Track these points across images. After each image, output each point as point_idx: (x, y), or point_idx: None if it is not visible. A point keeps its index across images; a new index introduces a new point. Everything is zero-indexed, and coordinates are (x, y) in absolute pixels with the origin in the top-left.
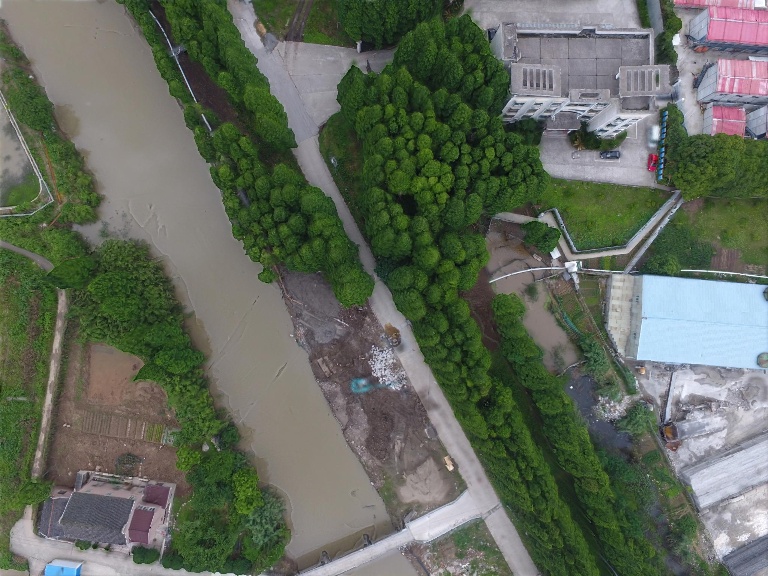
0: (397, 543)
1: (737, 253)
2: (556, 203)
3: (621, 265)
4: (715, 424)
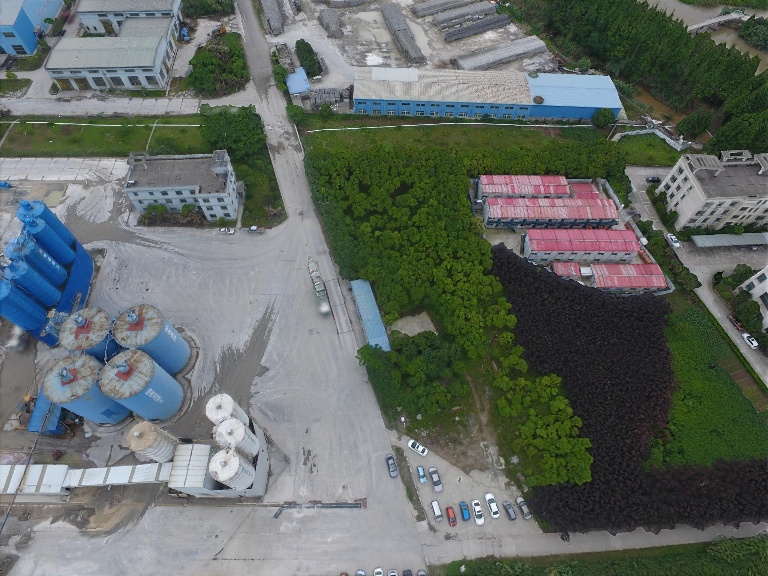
0: (688, 28)
1: (544, 135)
2: (678, 154)
3: (619, 128)
4: (532, 67)
